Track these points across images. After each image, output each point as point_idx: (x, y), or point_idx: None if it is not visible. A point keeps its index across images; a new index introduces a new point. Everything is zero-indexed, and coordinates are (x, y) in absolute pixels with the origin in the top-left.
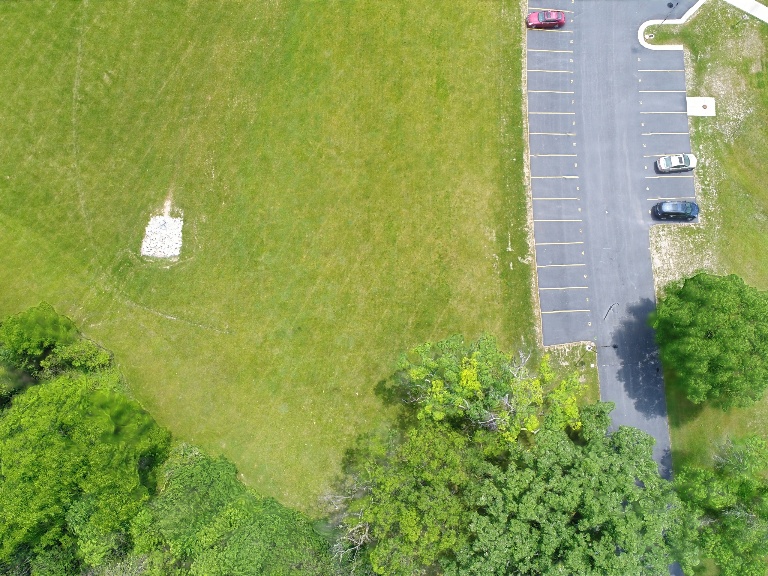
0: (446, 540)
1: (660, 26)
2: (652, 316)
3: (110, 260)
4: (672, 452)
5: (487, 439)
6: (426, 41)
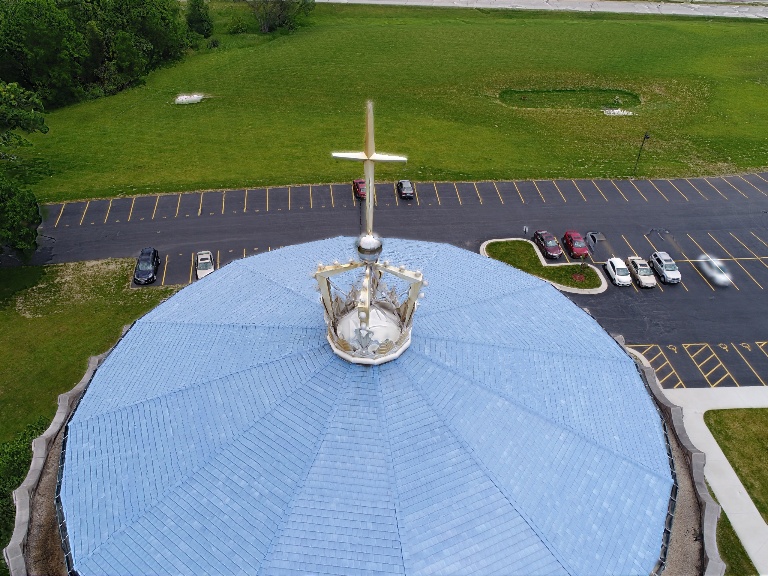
0: None
1: None
2: (30, 262)
3: None
4: None
5: None
6: None
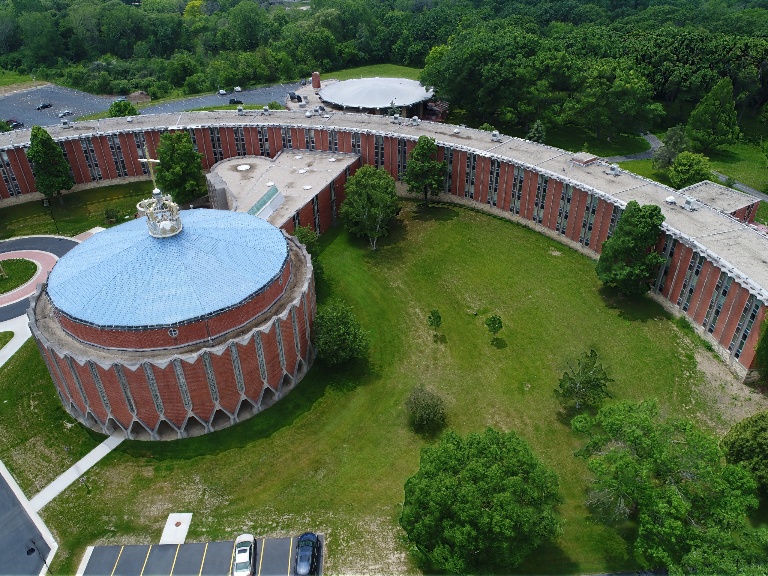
0: None
1: (49, 574)
2: None
3: None
4: (613, 572)
5: None
6: None
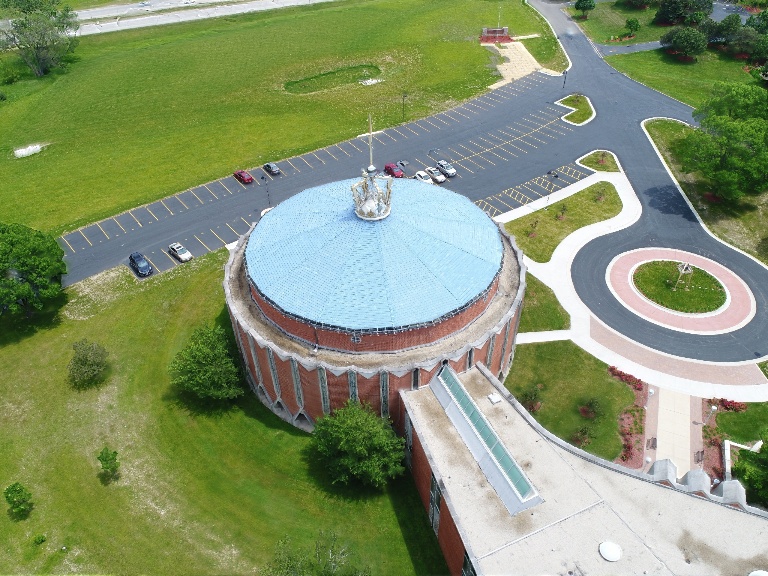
0: None
1: None
2: None
3: (6, 147)
4: None
5: None
6: None
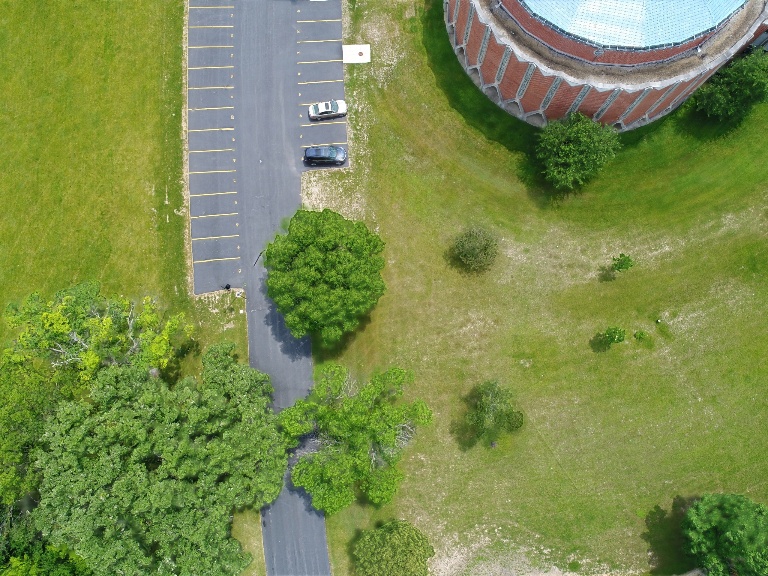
0: (4, 476)
1: None
2: None
3: None
4: (315, 392)
5: (63, 378)
6: (95, 4)
